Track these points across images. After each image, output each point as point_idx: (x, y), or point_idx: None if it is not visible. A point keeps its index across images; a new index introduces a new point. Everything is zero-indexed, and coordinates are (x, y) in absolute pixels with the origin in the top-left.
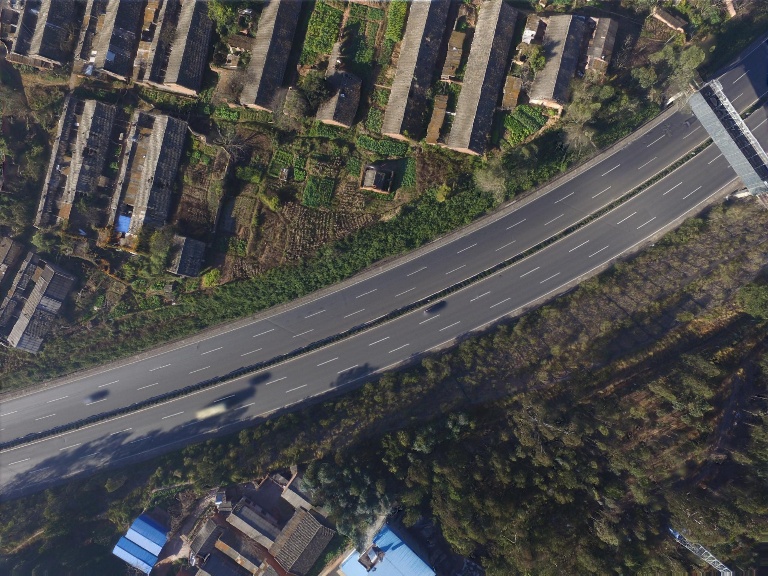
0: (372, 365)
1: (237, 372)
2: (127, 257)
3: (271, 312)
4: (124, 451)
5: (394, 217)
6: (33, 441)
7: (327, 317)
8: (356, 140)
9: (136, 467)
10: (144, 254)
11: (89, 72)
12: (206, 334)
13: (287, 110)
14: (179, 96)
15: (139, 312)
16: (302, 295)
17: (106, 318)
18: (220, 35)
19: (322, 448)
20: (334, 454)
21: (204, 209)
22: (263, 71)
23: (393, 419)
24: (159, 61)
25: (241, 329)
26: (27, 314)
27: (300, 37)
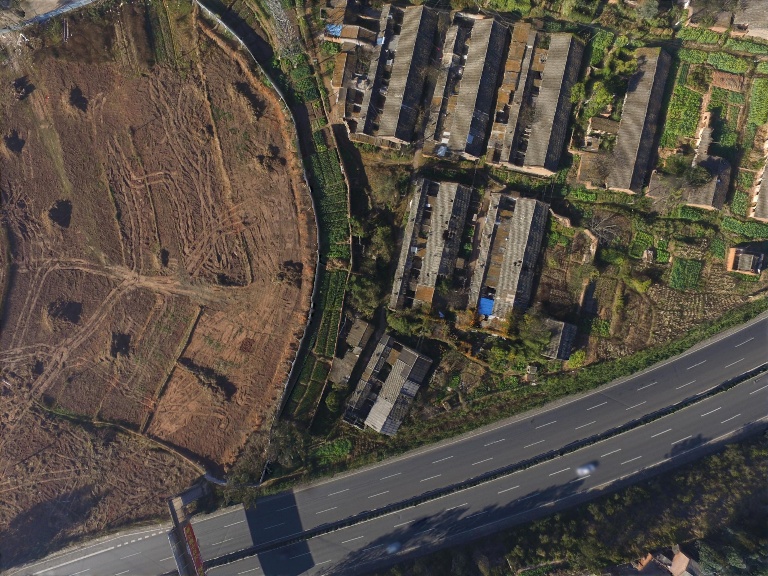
0: (706, 436)
1: (573, 445)
2: (483, 338)
3: (603, 385)
4: (461, 526)
5: (762, 298)
6: (369, 519)
7: (659, 389)
8: (720, 222)
9: (479, 543)
10: (513, 337)
11: (442, 153)
12: (540, 408)
13: (655, 194)
14: (531, 176)
15: (497, 393)
16: (642, 369)
17: (465, 400)
18: (577, 117)
19: (700, 527)
20: (715, 533)
21: (564, 290)
22: (637, 156)
23: (762, 495)
24: (516, 143)
25: (575, 402)
26: (388, 398)
27: (659, 120)
